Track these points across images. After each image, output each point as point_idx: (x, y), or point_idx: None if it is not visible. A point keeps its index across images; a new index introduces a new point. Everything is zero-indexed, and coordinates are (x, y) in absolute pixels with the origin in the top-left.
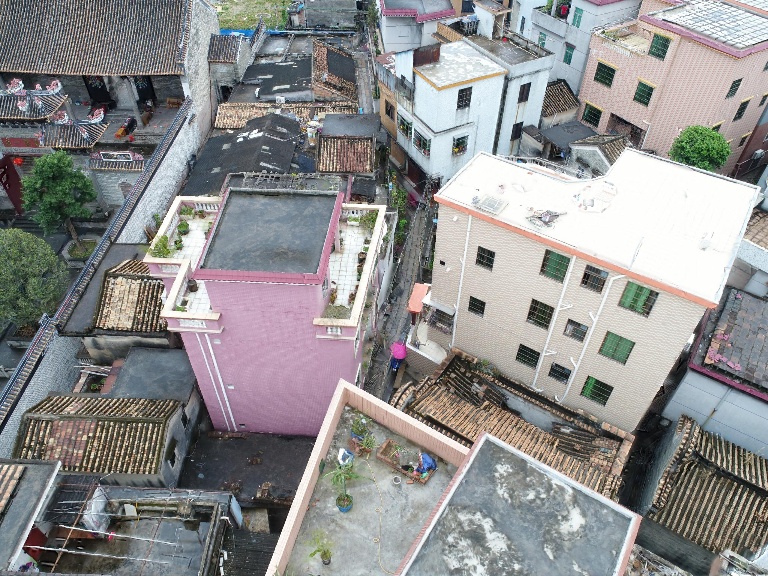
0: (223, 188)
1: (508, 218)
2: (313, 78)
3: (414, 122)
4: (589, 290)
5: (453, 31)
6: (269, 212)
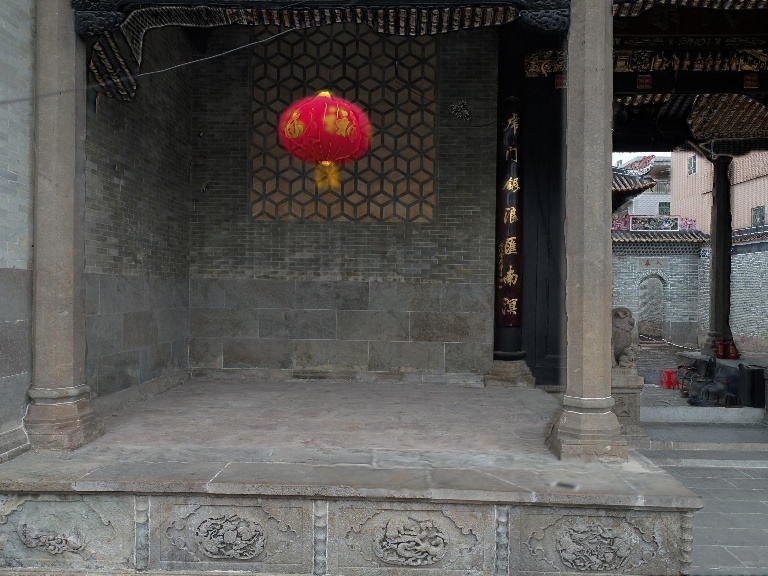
0: None
1: None
2: None
3: None
4: None
5: None
6: None
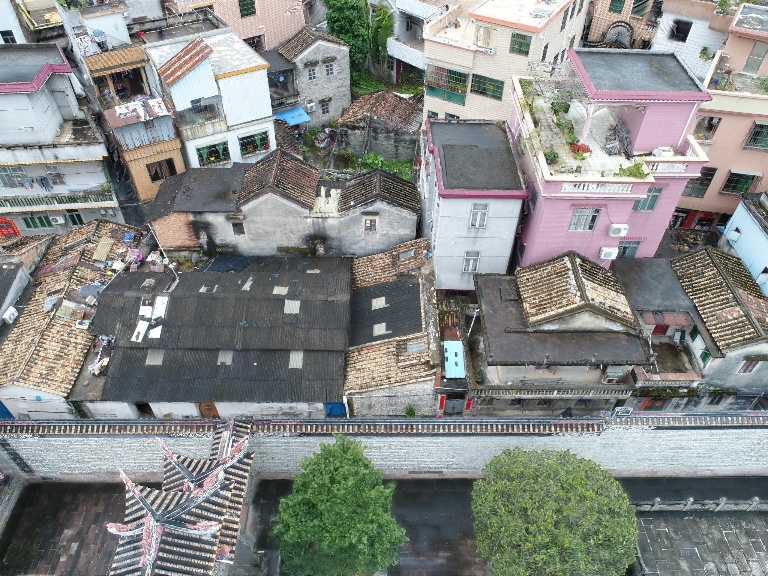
0: (473, 190)
1: (553, 9)
2: (1, 254)
3: (230, 136)
4: (571, 19)
5: (121, 50)
6: (612, 77)
